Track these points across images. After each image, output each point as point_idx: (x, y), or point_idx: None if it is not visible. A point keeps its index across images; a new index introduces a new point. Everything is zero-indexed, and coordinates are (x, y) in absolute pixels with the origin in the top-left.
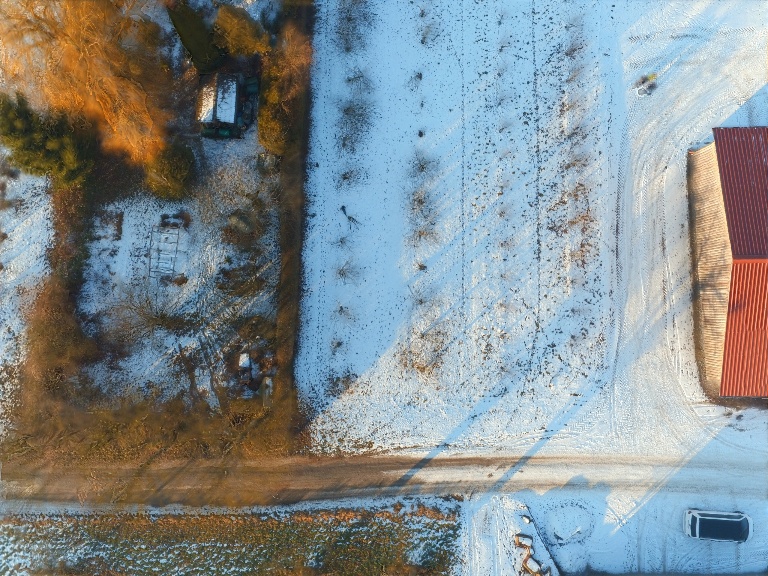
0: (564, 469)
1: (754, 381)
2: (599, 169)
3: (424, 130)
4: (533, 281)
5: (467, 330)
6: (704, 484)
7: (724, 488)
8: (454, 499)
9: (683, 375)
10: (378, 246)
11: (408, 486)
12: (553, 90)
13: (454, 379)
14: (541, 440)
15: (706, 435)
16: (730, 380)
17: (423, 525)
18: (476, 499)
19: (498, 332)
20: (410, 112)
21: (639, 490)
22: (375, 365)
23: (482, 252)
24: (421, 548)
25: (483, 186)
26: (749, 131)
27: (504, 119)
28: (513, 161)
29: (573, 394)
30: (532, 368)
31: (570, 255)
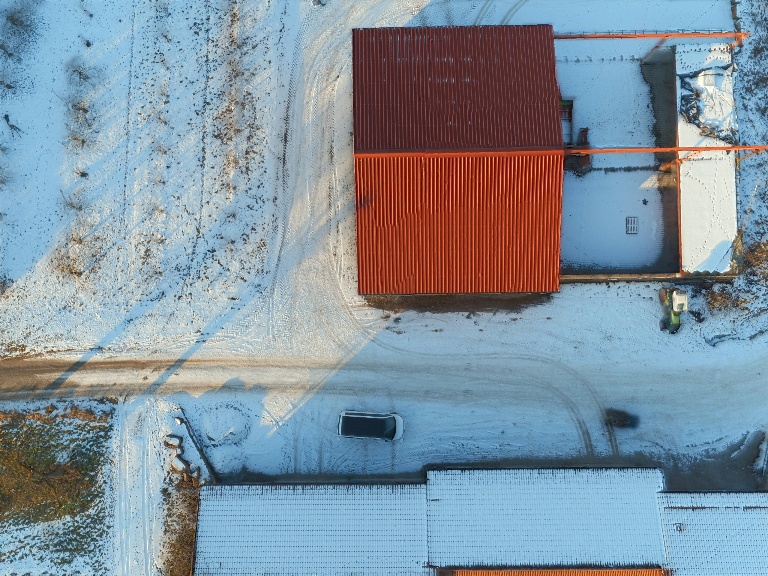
0: (220, 372)
1: (390, 278)
2: (268, 78)
3: (92, 40)
4: (196, 188)
5: (127, 236)
6: (361, 386)
7: (382, 390)
8: (109, 402)
9: (344, 279)
10: (40, 154)
11: (62, 389)
12: (225, 1)
13: (112, 284)
14: (197, 343)
15: (363, 338)
16: (366, 277)
17: (74, 427)
18: (130, 402)
19: (158, 238)
20: (79, 22)
21: (296, 392)
22: (32, 270)
23: (146, 159)
24: (70, 449)
25: (149, 95)
26: (388, 31)
27: (174, 29)
28: (181, 70)
29: (231, 298)
30: (191, 273)
31: (234, 162)
